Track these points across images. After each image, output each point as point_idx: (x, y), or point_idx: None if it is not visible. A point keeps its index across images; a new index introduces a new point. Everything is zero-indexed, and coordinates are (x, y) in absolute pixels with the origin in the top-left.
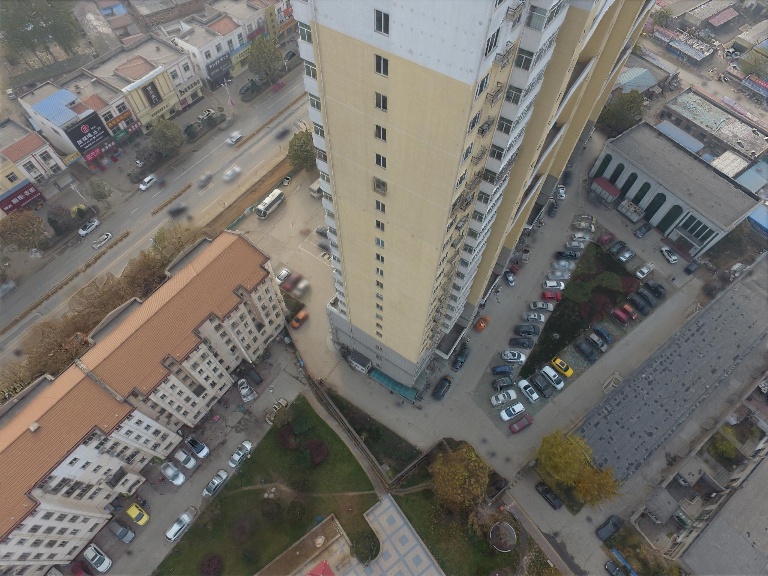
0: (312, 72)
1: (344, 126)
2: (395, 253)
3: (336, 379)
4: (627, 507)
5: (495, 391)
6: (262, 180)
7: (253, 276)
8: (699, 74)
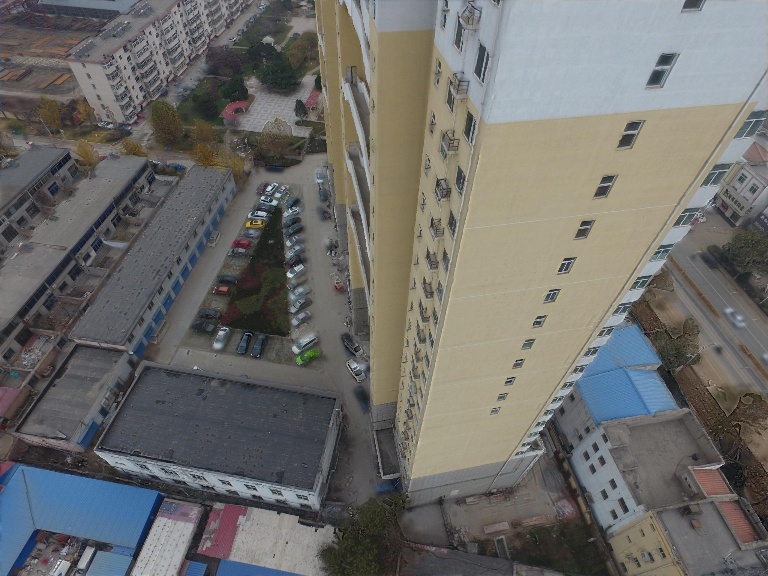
0: None
1: None
2: None
3: None
4: None
5: None
6: None
7: None
8: None
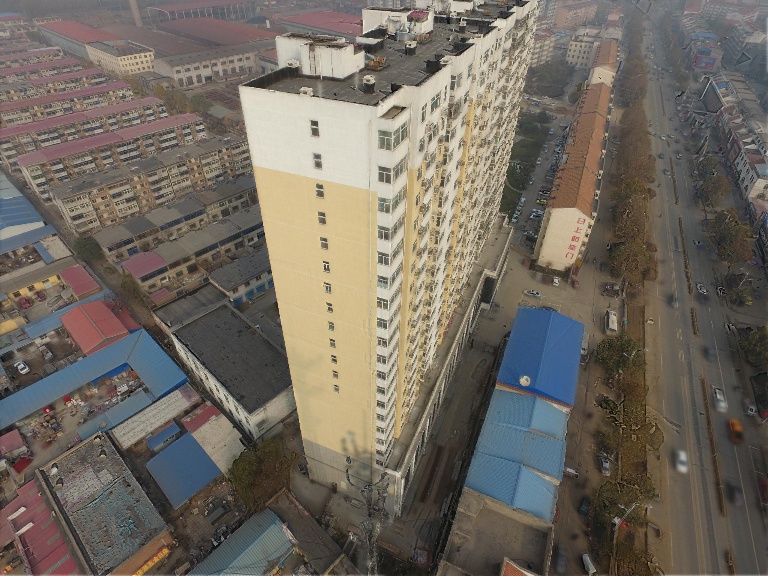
0: None
1: None
2: None
3: None
4: None
5: None
6: None
7: None
8: None
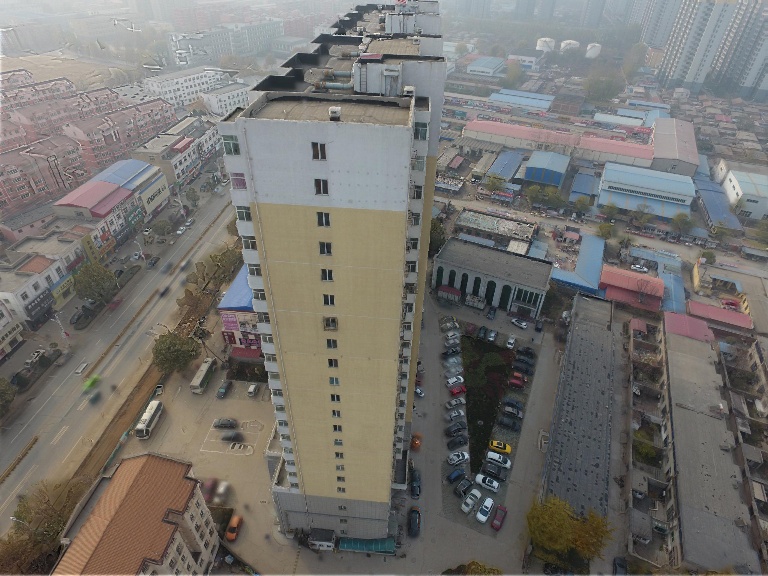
0: (251, 245)
1: (288, 281)
2: (352, 385)
3: (304, 574)
4: (619, 544)
5: (461, 499)
6: (129, 399)
7: (180, 492)
8: (462, 199)
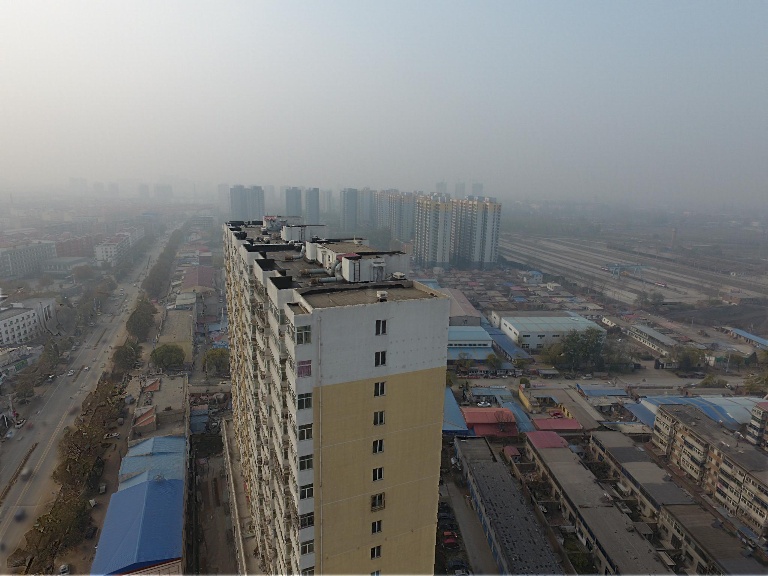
0: (307, 434)
1: (340, 465)
2: (394, 573)
3: None
4: None
5: None
6: None
7: None
8: None
